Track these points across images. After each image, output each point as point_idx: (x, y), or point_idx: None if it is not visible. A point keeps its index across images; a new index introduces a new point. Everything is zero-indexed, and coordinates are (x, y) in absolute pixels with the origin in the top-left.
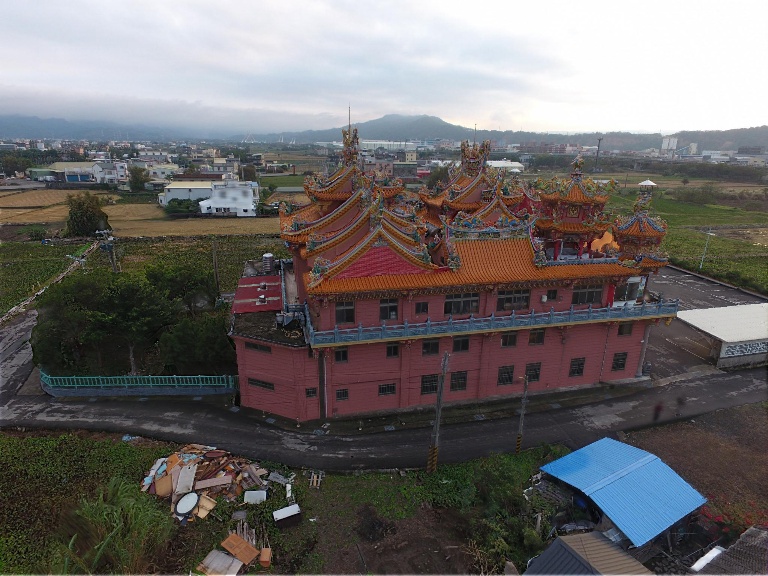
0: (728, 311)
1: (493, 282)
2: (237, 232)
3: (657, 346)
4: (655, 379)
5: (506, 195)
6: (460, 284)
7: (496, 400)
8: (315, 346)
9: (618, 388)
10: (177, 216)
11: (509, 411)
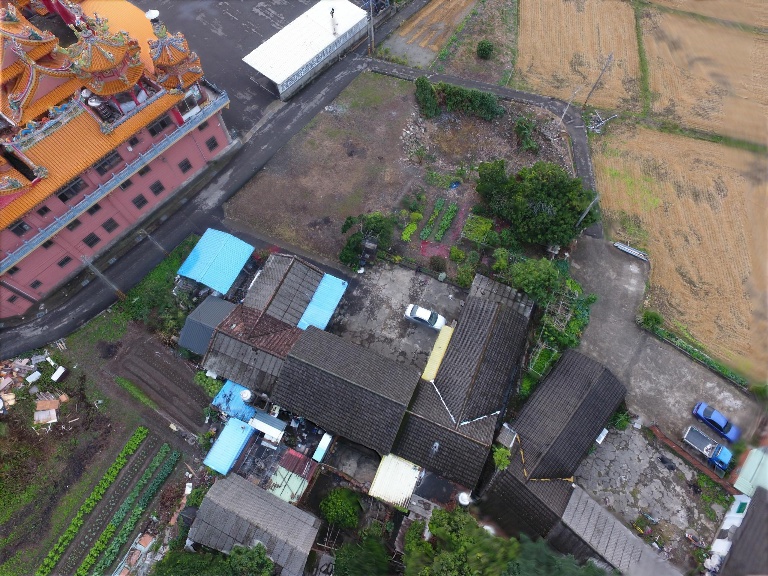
0: (283, 36)
1: (82, 171)
2: None
3: (244, 92)
4: (243, 136)
5: (39, 39)
6: (58, 188)
7: (144, 219)
8: None
9: (220, 161)
10: None
11: (156, 223)
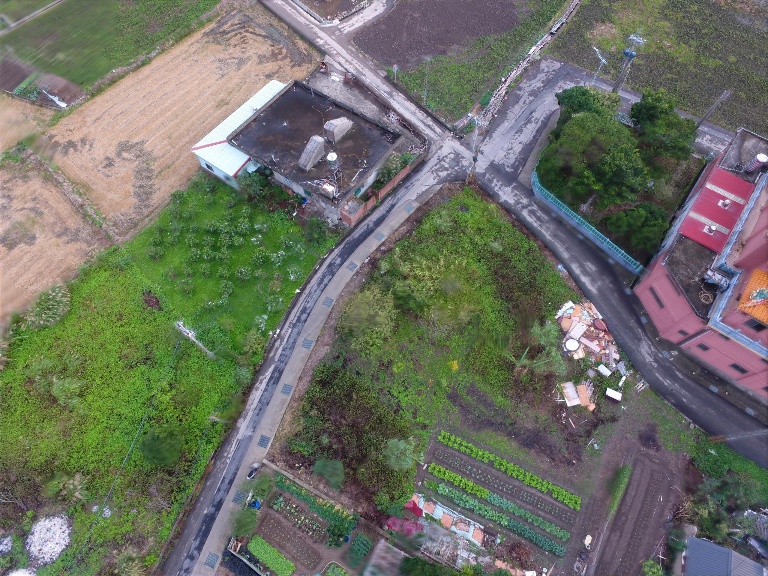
0: None
1: None
2: None
3: None
4: None
5: None
6: None
7: None
8: (711, 326)
9: None
10: None
11: None
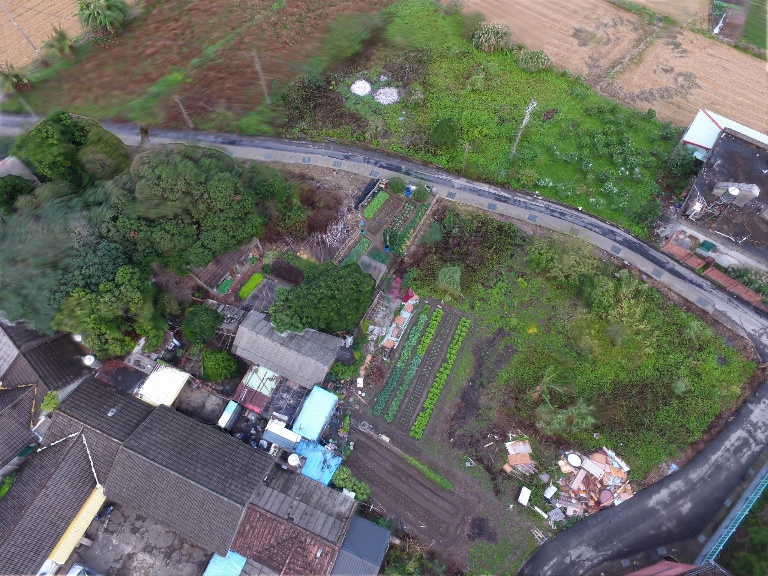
0: None
1: None
2: None
3: None
4: None
5: None
6: None
7: None
8: None
9: None
10: None
11: None
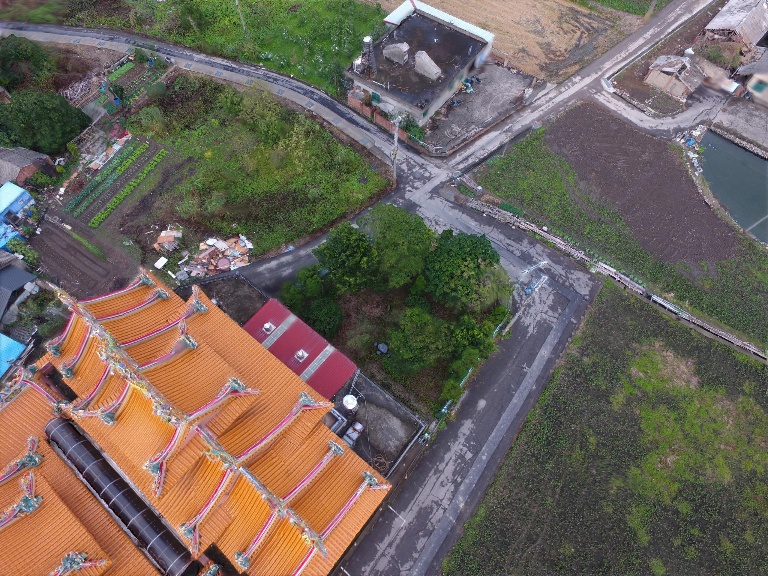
0: None
1: None
2: None
3: None
4: None
5: None
6: None
7: None
8: None
9: None
10: None
11: None
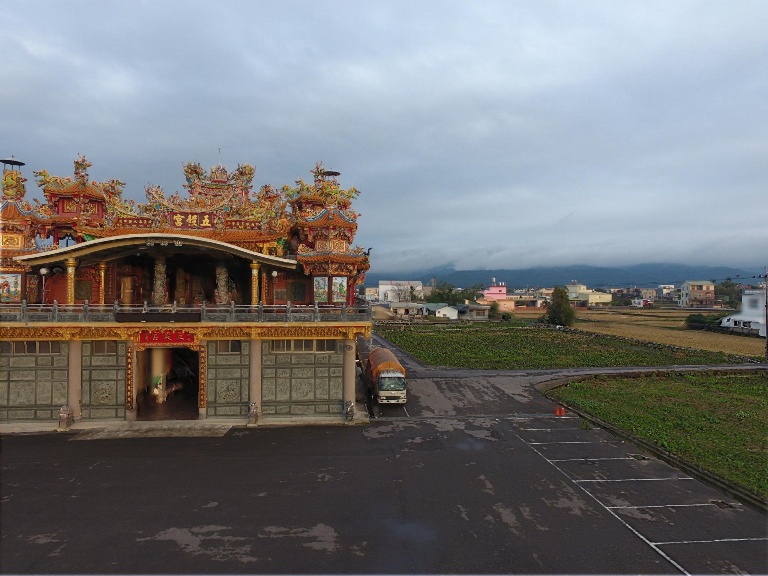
0: None
1: None
2: (648, 339)
3: None
4: None
5: None
6: None
7: None
8: None
9: None
10: (693, 327)
11: None
